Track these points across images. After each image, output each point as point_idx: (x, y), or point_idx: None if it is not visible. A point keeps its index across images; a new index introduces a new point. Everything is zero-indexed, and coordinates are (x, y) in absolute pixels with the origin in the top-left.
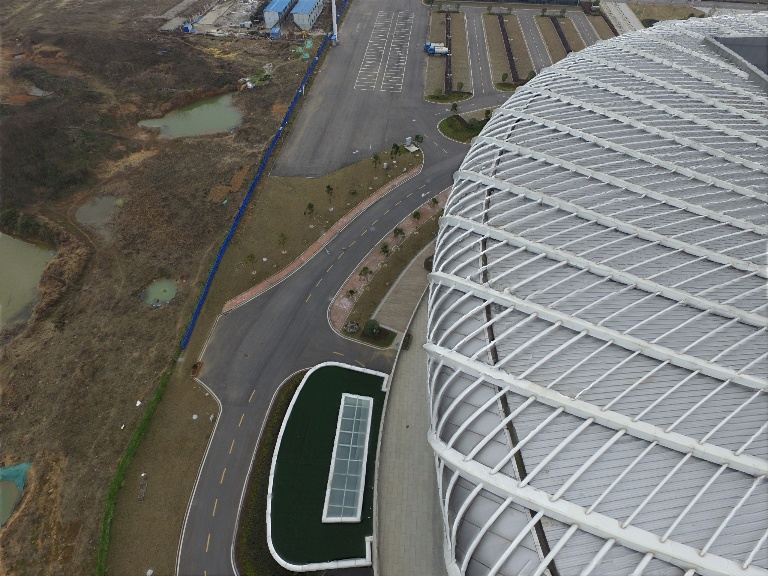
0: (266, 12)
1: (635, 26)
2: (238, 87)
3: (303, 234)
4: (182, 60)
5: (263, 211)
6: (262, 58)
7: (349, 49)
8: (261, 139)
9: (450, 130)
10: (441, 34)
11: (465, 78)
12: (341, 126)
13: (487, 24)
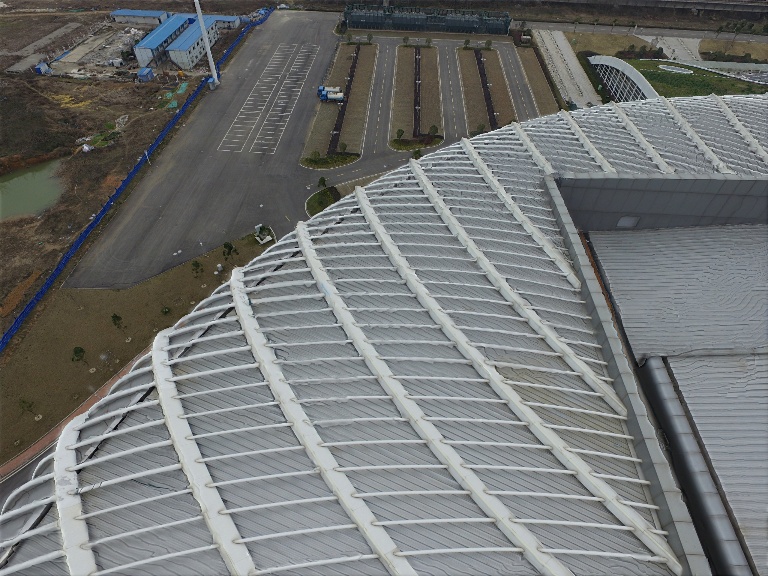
0: (136, 49)
1: (569, 60)
2: (72, 150)
3: (76, 384)
4: (10, 115)
5: (30, 348)
6: (118, 108)
7: (229, 94)
8: (72, 228)
9: (319, 209)
10: (344, 73)
11: (357, 133)
12: (183, 206)
13: (400, 59)
